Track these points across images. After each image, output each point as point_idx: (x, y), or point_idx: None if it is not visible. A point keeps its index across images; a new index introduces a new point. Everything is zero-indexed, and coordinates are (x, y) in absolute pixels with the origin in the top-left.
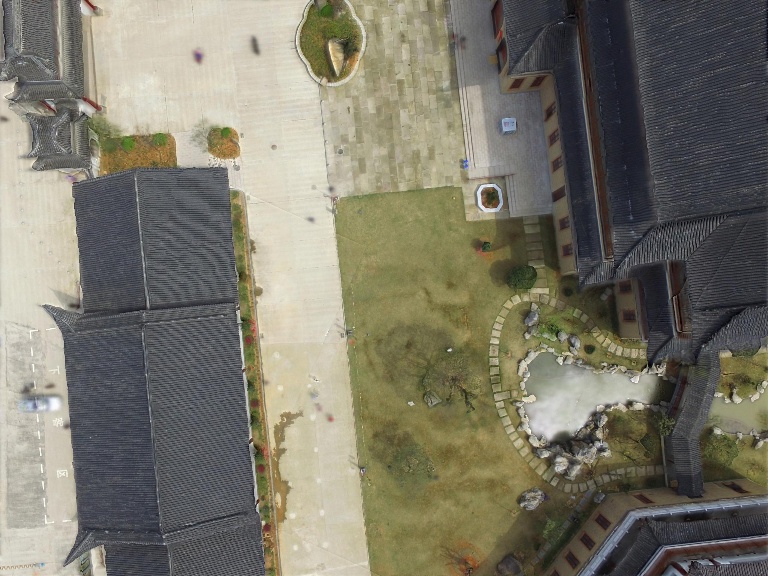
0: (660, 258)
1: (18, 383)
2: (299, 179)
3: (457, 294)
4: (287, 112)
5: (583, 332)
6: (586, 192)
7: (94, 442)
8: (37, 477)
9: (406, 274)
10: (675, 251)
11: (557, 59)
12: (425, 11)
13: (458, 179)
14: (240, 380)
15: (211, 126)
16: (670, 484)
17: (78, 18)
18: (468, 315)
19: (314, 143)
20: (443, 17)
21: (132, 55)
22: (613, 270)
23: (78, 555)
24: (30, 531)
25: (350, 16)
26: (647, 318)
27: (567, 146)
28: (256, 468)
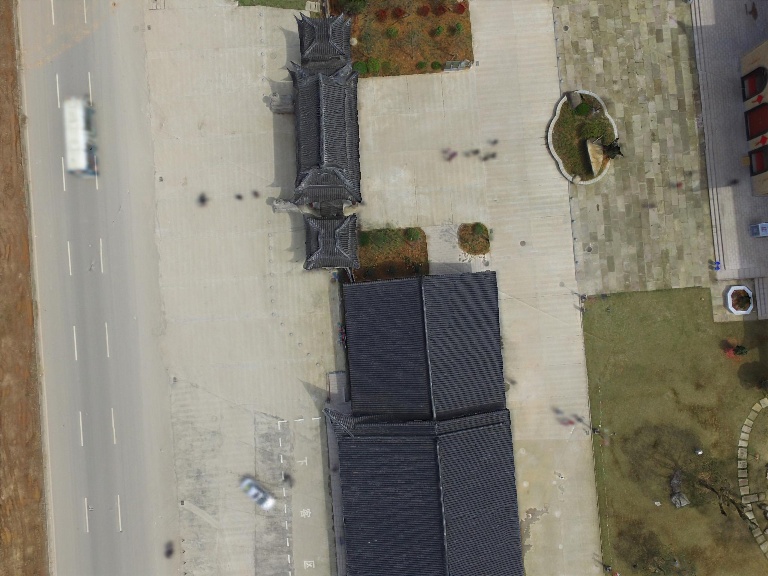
0: None
1: (267, 473)
2: (547, 276)
3: (705, 396)
4: (536, 208)
5: None
6: None
7: (374, 547)
8: (285, 567)
9: (654, 374)
10: None
11: None
12: (675, 110)
13: (706, 280)
14: (514, 487)
15: (460, 221)
16: None
17: (356, 120)
18: (717, 417)
19: (563, 240)
20: (693, 116)
21: (383, 148)
22: None
23: None
24: None
25: (603, 114)
26: None
27: None
28: None
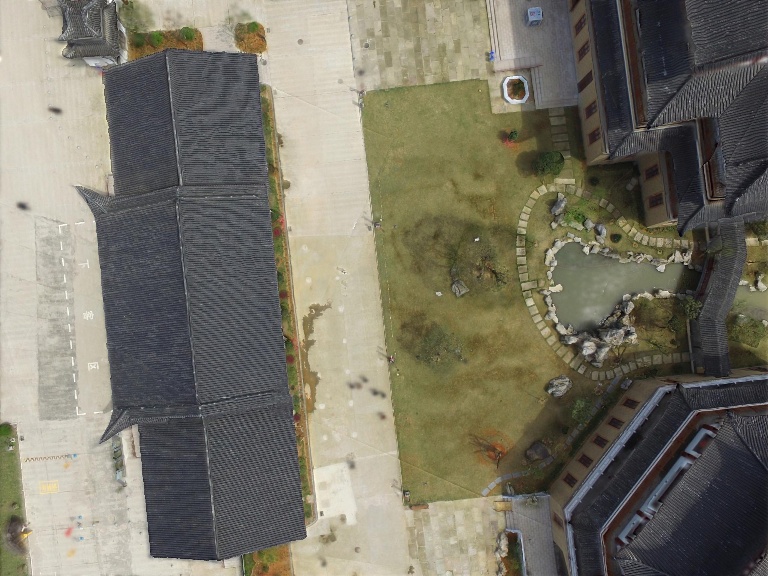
0: (693, 115)
1: (48, 277)
2: (325, 73)
3: (484, 185)
4: (313, 6)
5: (609, 222)
6: (616, 64)
7: (128, 321)
8: (68, 369)
9: (433, 166)
10: (708, 108)
11: None
12: None
13: (484, 72)
14: (272, 261)
15: (237, 21)
16: (696, 370)
17: None
18: (495, 206)
19: (340, 37)
20: None
21: None
22: (647, 126)
23: (113, 433)
24: (62, 423)
25: None
26: (677, 190)
27: (597, 20)
28: (286, 358)
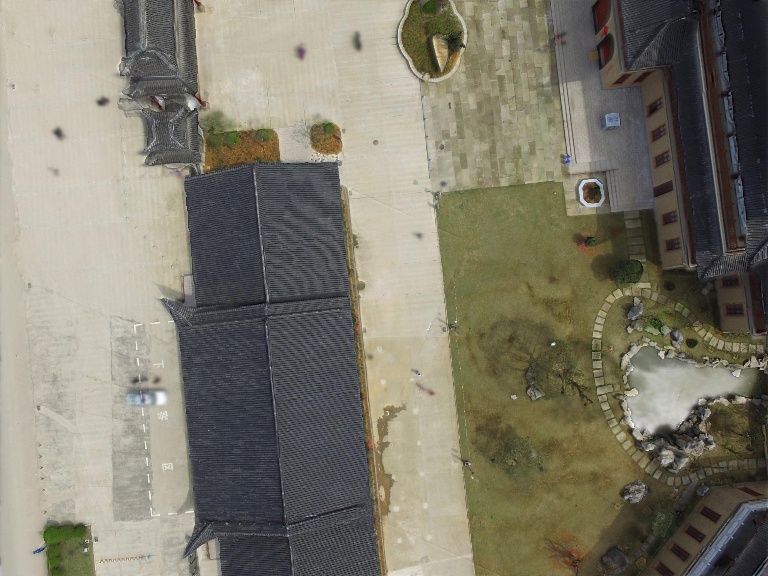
0: None
1: (123, 377)
2: (401, 174)
3: (559, 288)
4: (388, 108)
5: (685, 326)
6: (705, 186)
7: (213, 435)
8: (143, 470)
9: (508, 269)
10: None
11: (675, 54)
12: (525, 7)
13: (559, 174)
14: (355, 373)
15: (313, 122)
16: None
17: (191, 14)
18: (570, 309)
19: (415, 138)
20: (543, 13)
21: (234, 51)
22: (747, 263)
23: (196, 547)
24: (136, 524)
25: (451, 12)
26: (765, 311)
27: (685, 141)
28: None
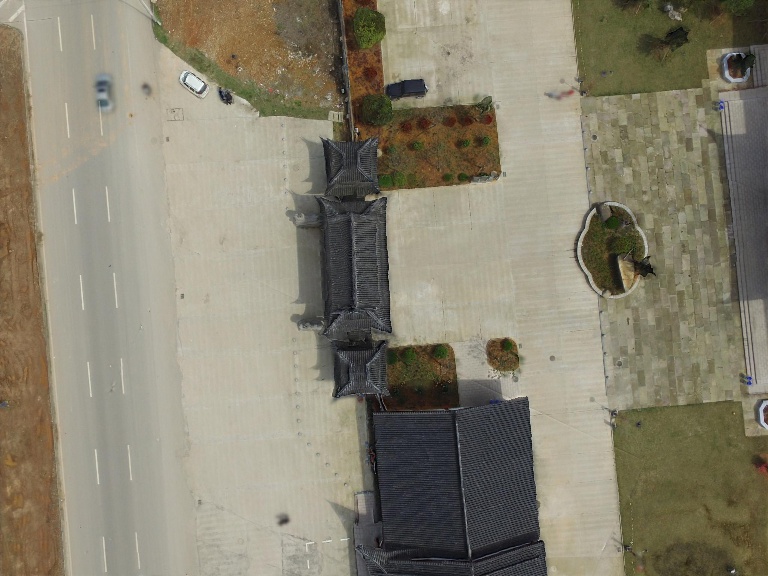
0: None
1: None
2: (577, 391)
3: (738, 512)
4: (566, 323)
5: None
6: None
7: None
8: None
9: (686, 490)
10: None
11: None
12: (706, 220)
13: (738, 393)
14: None
15: (489, 336)
16: None
17: (385, 247)
18: (749, 533)
19: (593, 354)
20: (724, 227)
21: (409, 262)
22: None
23: None
24: None
25: (633, 227)
26: None
27: None
28: None
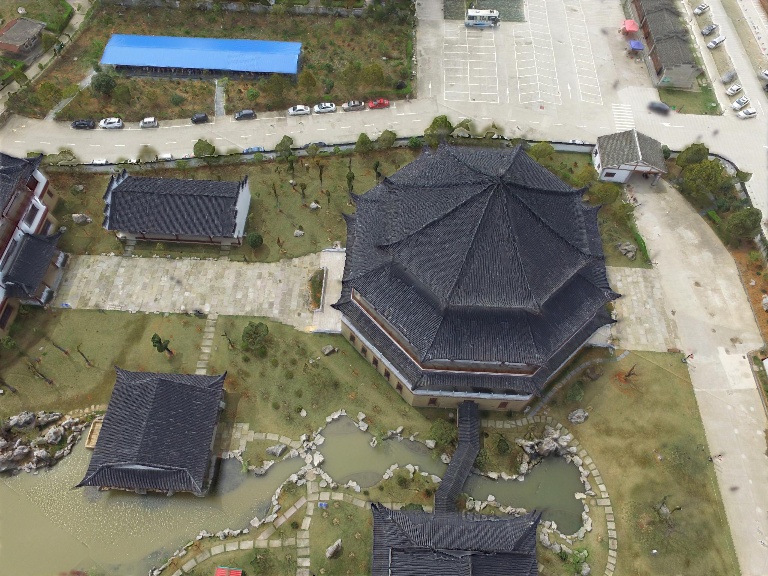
0: None
1: None
2: None
3: None
4: None
5: None
6: None
7: None
8: None
9: None
10: None
11: None
12: None
13: None
14: None
15: None
16: None
17: None
18: None
19: None
20: None
21: None
22: None
23: None
24: None
25: None
26: None
27: None
28: None
